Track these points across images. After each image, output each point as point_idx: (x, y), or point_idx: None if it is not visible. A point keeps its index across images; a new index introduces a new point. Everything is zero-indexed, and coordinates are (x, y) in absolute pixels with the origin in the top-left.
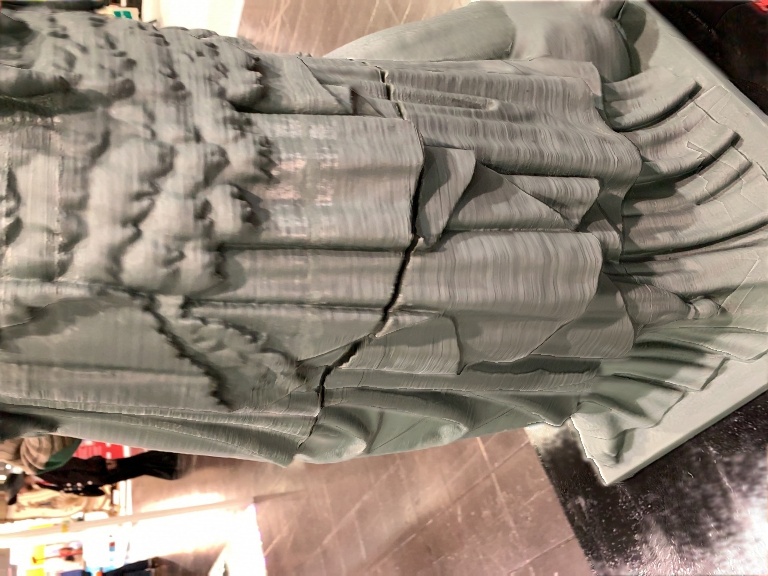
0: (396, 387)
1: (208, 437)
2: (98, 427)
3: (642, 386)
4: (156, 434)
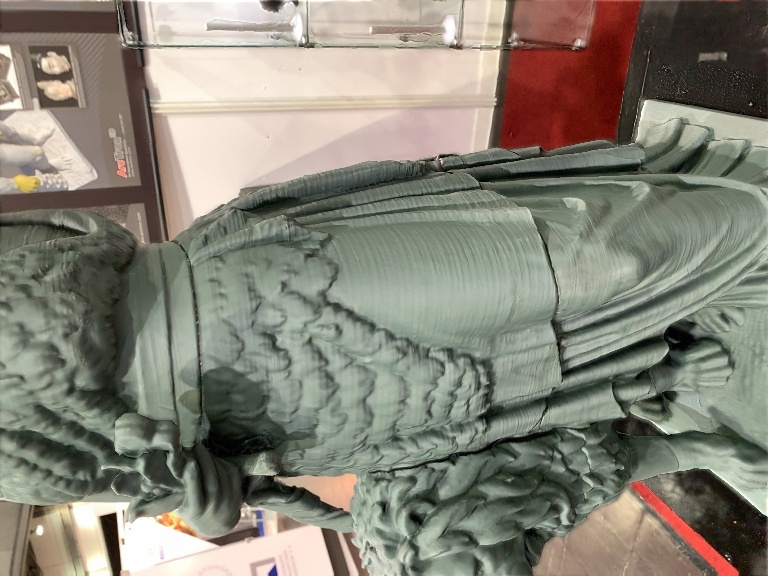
0: (498, 166)
1: (434, 212)
2: (357, 232)
3: (742, 168)
4: (401, 227)
